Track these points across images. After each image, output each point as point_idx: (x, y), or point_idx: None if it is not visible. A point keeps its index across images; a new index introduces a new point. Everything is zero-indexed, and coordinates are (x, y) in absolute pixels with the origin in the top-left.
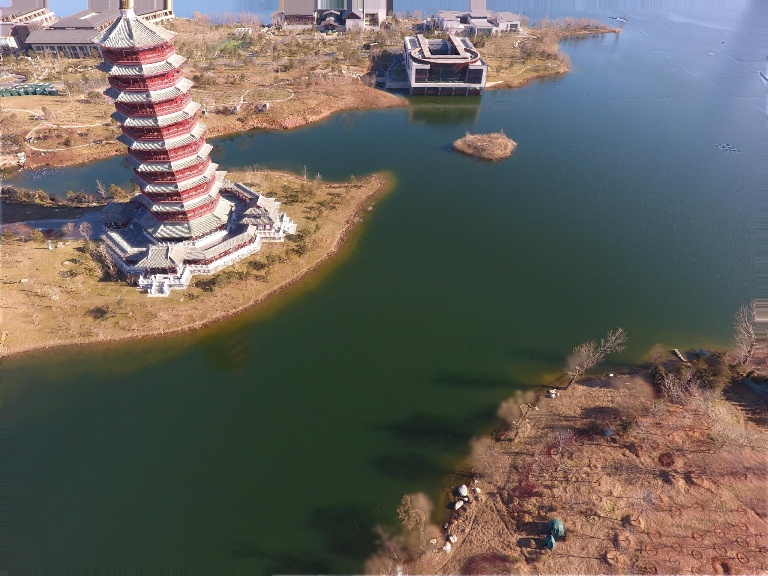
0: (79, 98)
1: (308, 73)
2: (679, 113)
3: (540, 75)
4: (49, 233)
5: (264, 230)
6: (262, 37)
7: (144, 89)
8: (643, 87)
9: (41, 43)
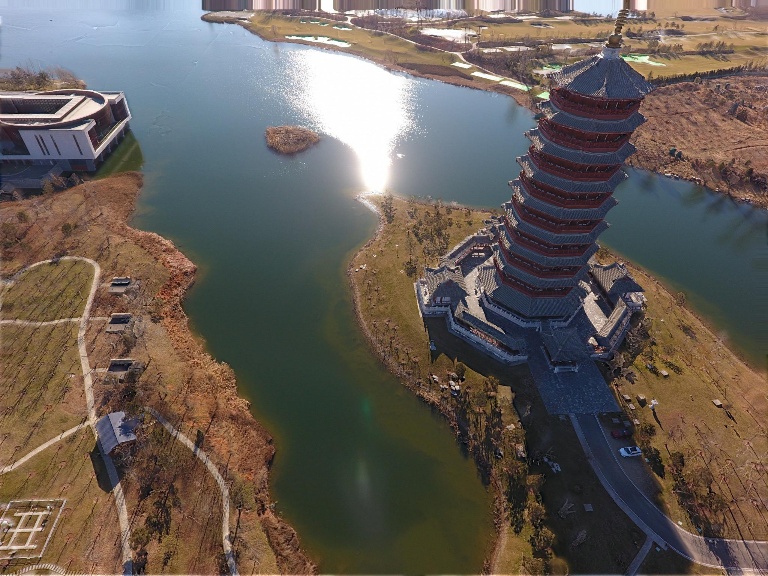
0: None
1: (6, 227)
2: (233, 65)
3: None
4: None
5: None
6: None
7: None
8: (160, 64)
9: None
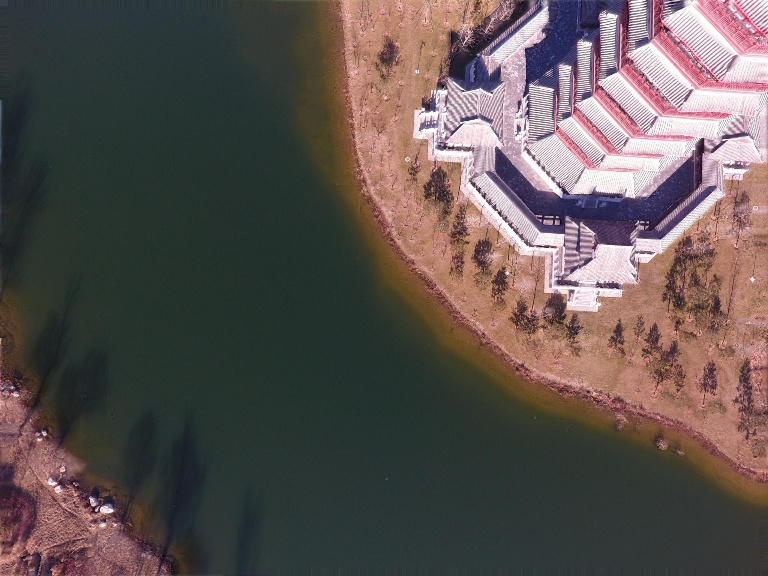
0: None
1: None
2: None
3: None
4: None
5: None
6: None
7: None
8: None
9: None
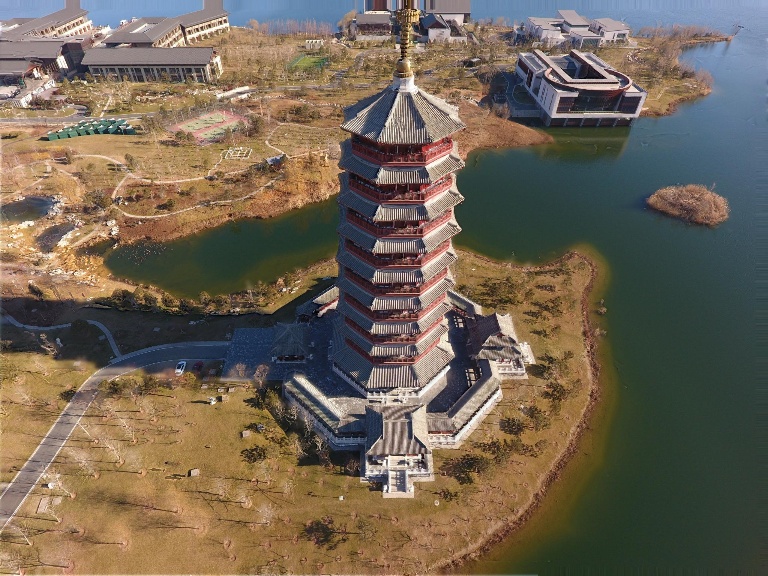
0: (162, 138)
1: None
2: None
3: (684, 98)
4: (199, 370)
5: (500, 362)
6: (345, 52)
7: (417, 201)
8: None
9: (100, 65)
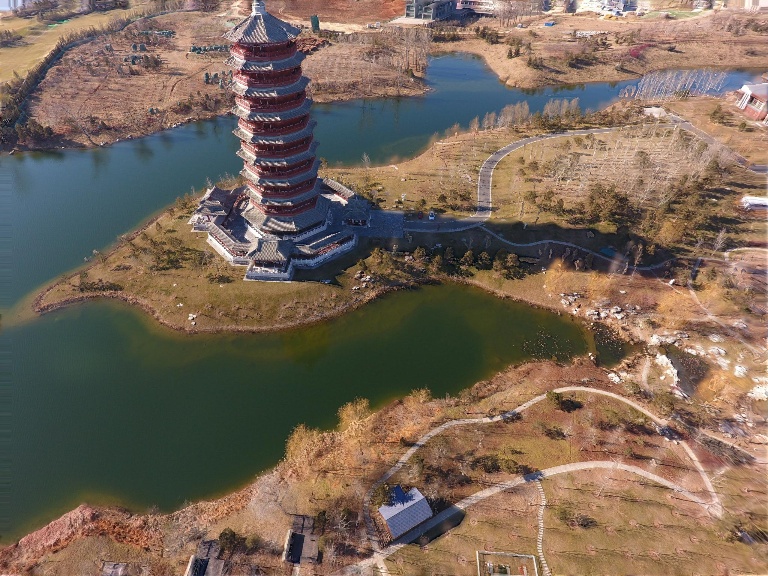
0: None
1: None
2: None
3: None
4: None
5: None
6: None
7: None
8: None
9: None
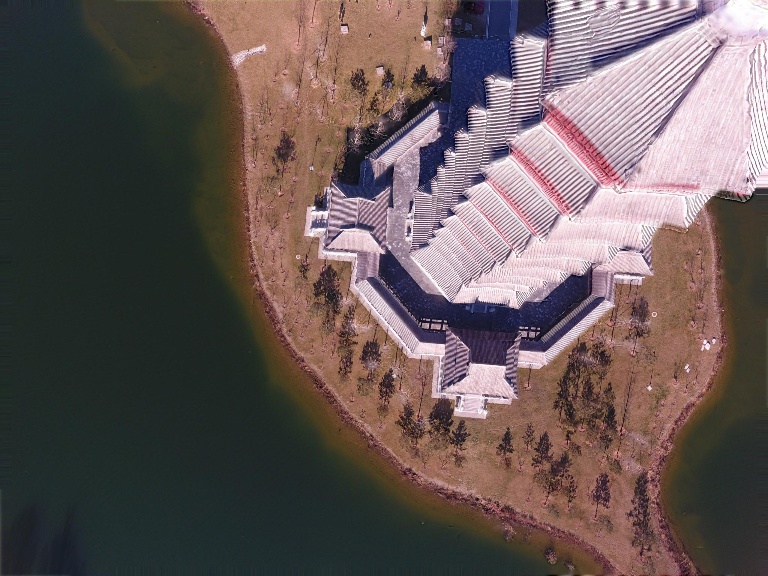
0: None
1: None
2: None
3: None
4: (470, 12)
5: None
6: None
7: None
8: None
9: None
